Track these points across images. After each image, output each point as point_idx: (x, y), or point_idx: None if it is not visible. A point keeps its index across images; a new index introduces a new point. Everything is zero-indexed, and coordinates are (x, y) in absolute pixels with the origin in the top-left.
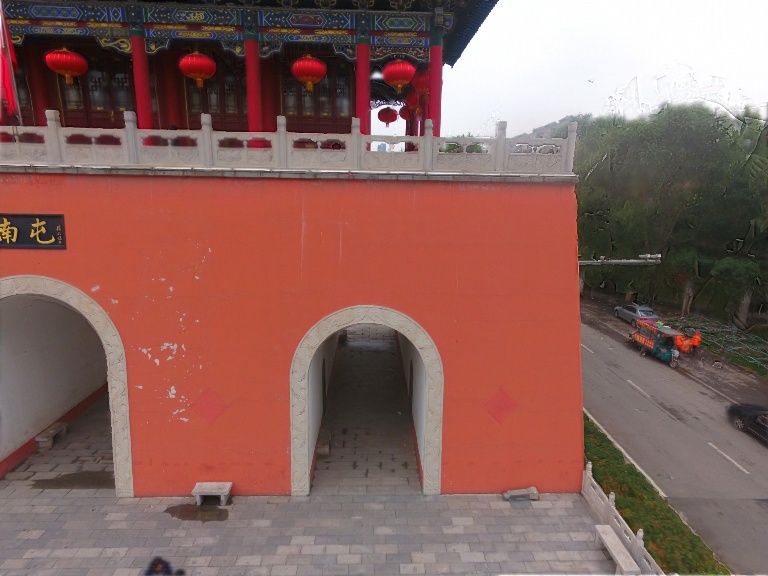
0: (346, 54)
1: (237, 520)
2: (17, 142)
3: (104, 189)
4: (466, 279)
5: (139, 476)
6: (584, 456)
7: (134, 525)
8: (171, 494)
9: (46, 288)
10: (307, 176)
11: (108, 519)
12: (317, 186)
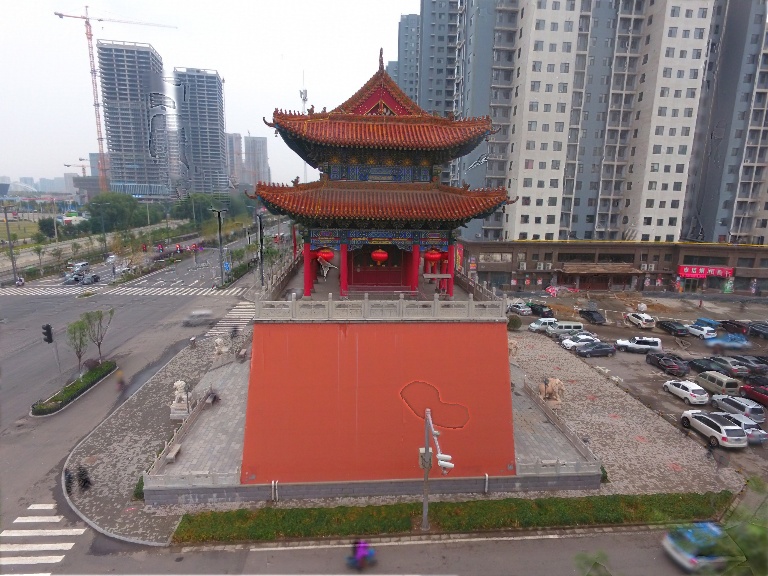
0: None
1: None
2: None
3: None
4: None
5: None
6: (242, 464)
7: None
8: None
9: None
10: None
11: None
12: None
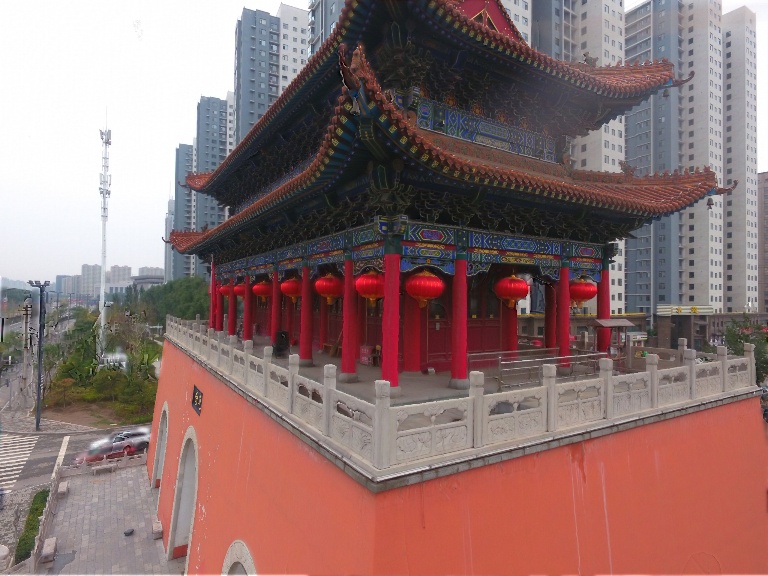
0: (343, 271)
1: None
2: (205, 346)
3: (210, 381)
4: (291, 575)
5: None
6: None
7: None
8: None
9: None
10: (244, 396)
11: None
12: (248, 407)
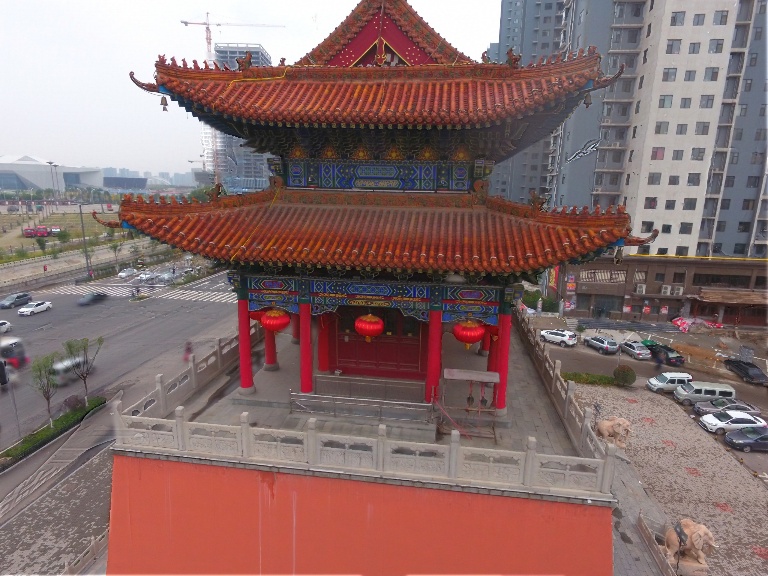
0: None
1: None
2: None
3: None
4: None
5: None
6: None
7: None
8: None
9: None
10: None
11: None
12: None
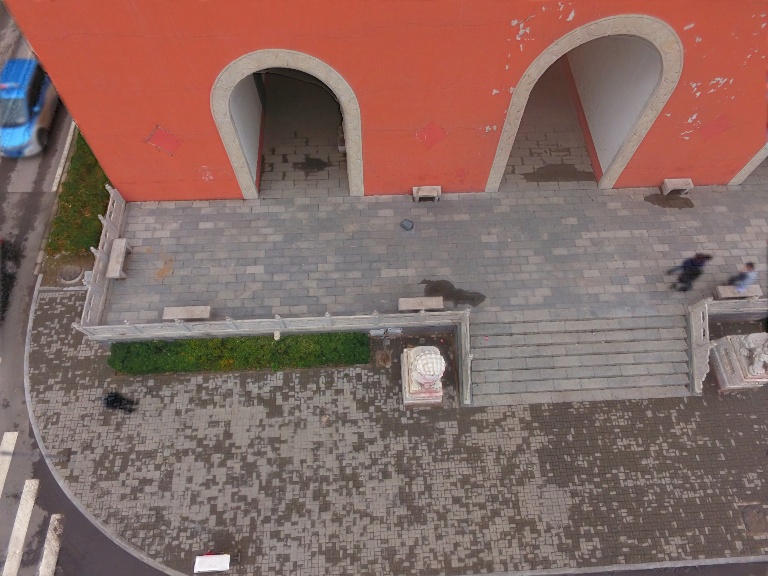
0: None
1: (702, 207)
2: None
3: None
4: None
5: (623, 176)
6: None
7: (634, 212)
8: (639, 186)
9: (641, 28)
10: None
11: (611, 208)
12: None
